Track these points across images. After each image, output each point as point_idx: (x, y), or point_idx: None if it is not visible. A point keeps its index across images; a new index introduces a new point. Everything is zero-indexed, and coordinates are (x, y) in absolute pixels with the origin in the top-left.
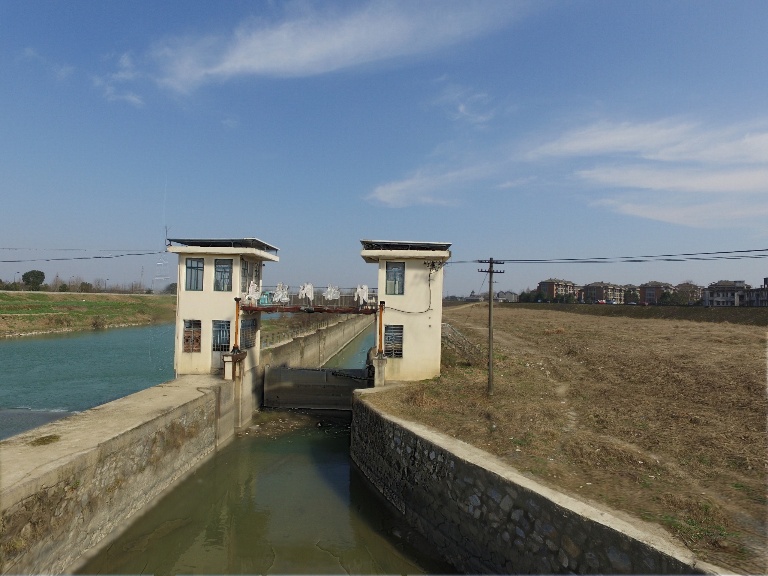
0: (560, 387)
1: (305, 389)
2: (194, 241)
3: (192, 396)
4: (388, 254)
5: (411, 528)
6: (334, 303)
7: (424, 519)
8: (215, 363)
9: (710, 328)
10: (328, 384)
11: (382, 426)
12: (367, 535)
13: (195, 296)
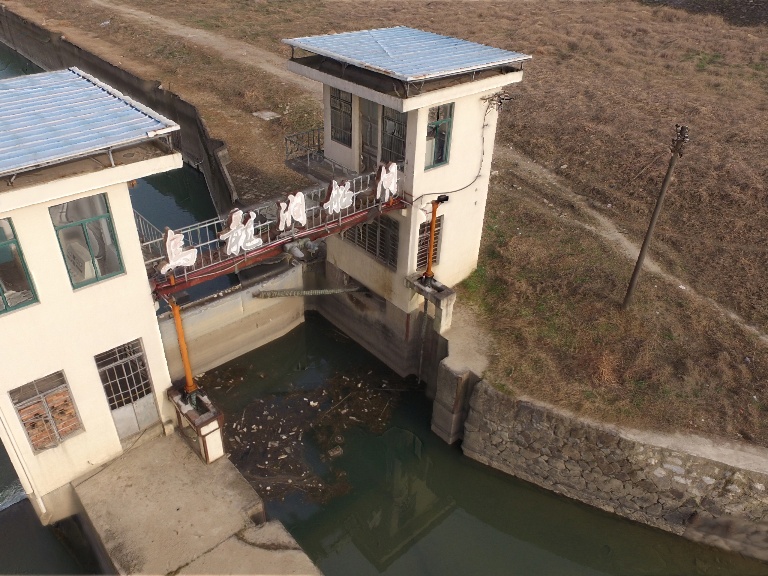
0: (626, 246)
1: (210, 339)
2: None
3: None
4: (445, 98)
5: (711, 551)
6: (339, 214)
7: (736, 541)
8: (125, 429)
9: (471, 6)
10: (247, 314)
11: (626, 450)
12: (539, 538)
13: (22, 325)
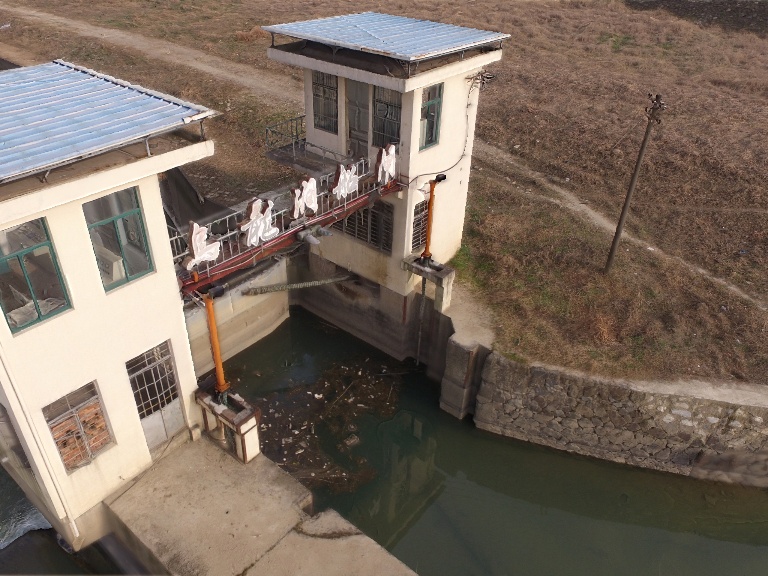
0: (593, 216)
1: (202, 343)
2: (15, 178)
3: (381, 564)
4: (440, 77)
5: (716, 486)
6: (345, 199)
7: (738, 473)
8: (153, 438)
9: None
10: (237, 313)
11: (638, 401)
12: (551, 499)
13: (56, 334)
